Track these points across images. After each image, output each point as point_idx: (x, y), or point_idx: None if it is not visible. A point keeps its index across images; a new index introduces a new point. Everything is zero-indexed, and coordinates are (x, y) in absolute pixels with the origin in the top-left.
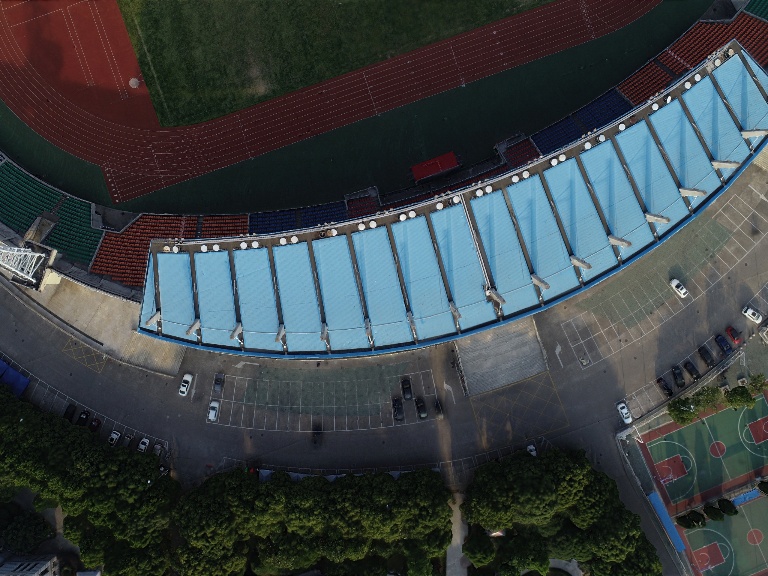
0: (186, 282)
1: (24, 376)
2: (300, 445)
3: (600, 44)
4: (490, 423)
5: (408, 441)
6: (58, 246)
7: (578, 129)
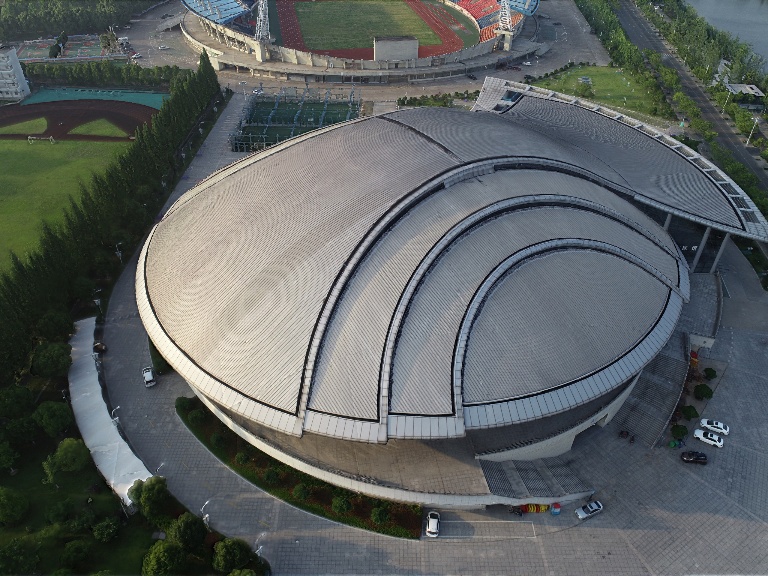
0: None
1: None
2: (171, 7)
3: None
4: None
5: None
6: None
7: (246, 31)
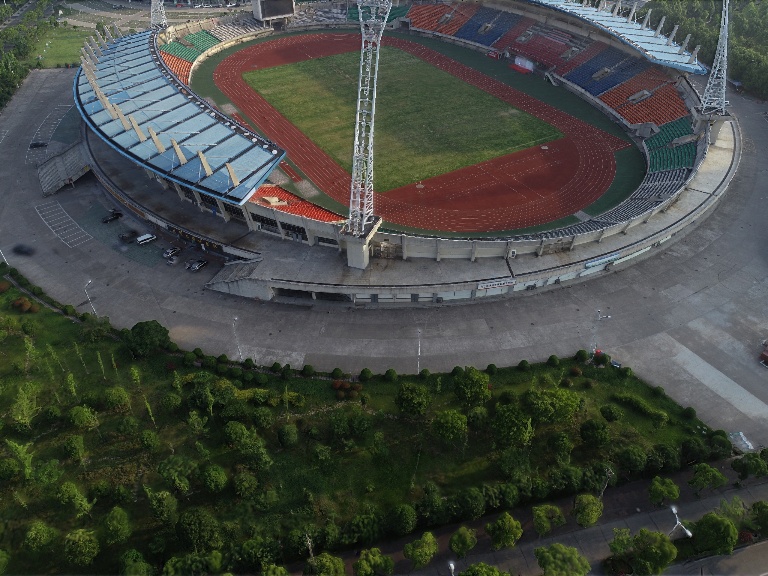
0: None
1: None
2: None
3: None
4: None
5: None
6: (687, 131)
7: None
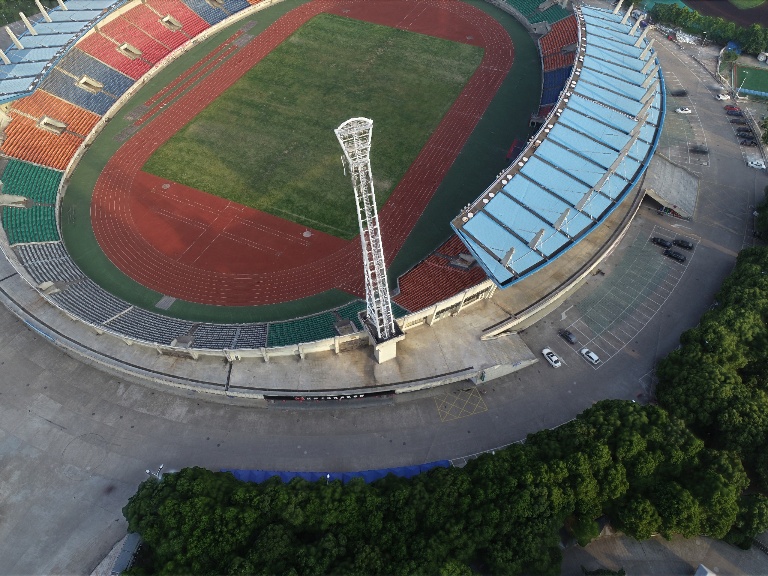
0: (497, 229)
1: (439, 461)
2: (664, 326)
3: (513, 72)
4: (721, 222)
5: (706, 267)
6: None
7: (554, 89)
